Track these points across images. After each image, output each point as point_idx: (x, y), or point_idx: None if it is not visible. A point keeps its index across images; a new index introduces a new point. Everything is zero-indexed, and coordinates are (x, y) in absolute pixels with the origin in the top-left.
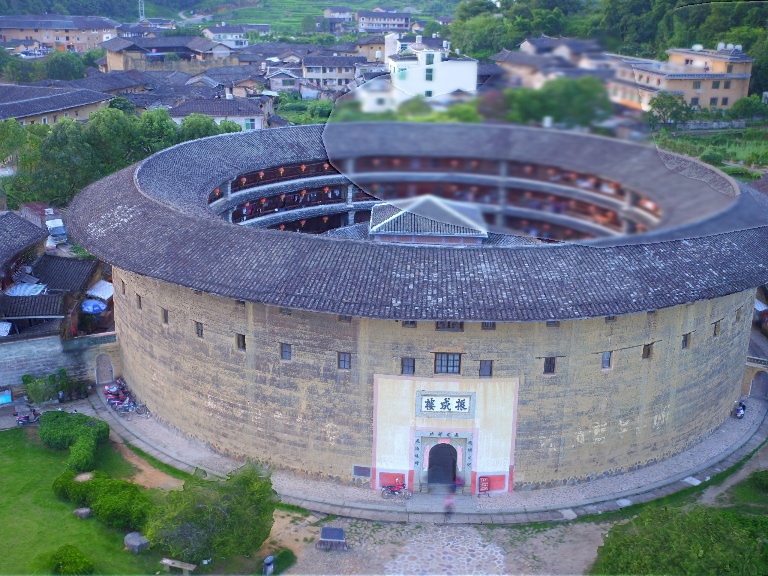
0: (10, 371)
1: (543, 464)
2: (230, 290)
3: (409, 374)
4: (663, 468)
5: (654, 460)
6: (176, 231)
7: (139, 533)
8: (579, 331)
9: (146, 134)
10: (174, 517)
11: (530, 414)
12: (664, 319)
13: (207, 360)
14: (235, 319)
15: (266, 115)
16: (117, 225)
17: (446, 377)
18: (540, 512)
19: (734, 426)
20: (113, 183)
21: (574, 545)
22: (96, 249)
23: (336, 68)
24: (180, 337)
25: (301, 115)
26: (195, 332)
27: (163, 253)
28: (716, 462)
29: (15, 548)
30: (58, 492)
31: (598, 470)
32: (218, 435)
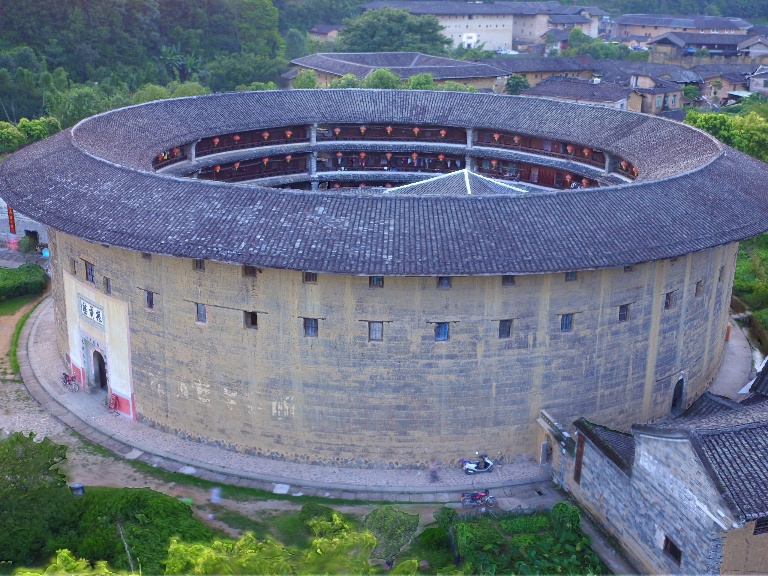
0: None
1: (156, 403)
2: None
3: None
4: (281, 466)
5: (282, 455)
6: None
7: None
8: (169, 271)
9: None
10: None
11: (140, 345)
12: (268, 288)
13: None
14: None
15: (656, 108)
16: None
17: (89, 285)
18: (120, 442)
19: (442, 475)
20: None
21: (84, 472)
22: None
23: None
24: None
25: (730, 116)
26: None
27: None
28: (339, 488)
29: None
30: None
31: (209, 435)
32: None
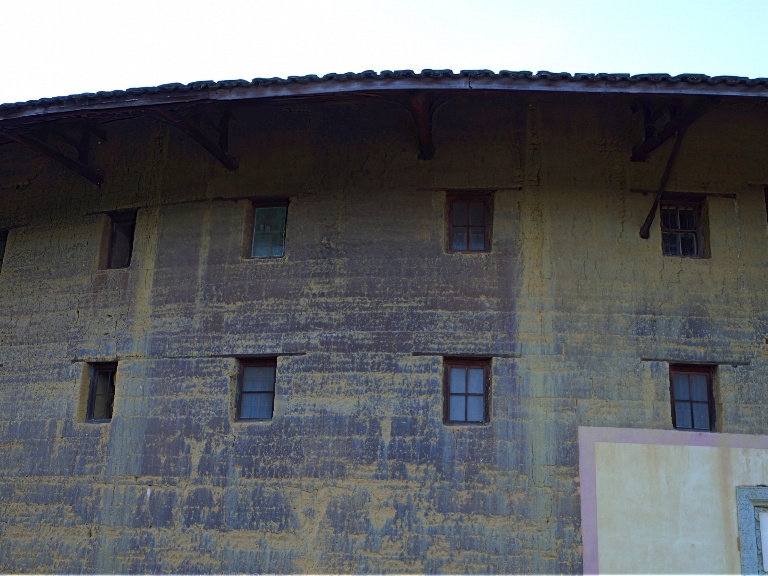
0: None
1: None
2: None
3: (696, 431)
4: None
5: None
6: None
7: None
8: None
9: None
10: None
11: None
12: None
13: None
14: (91, 314)
15: None
16: None
17: None
18: None
19: None
20: None
21: None
22: None
23: None
24: None
25: None
26: None
27: None
28: None
29: None
30: None
31: None
32: None
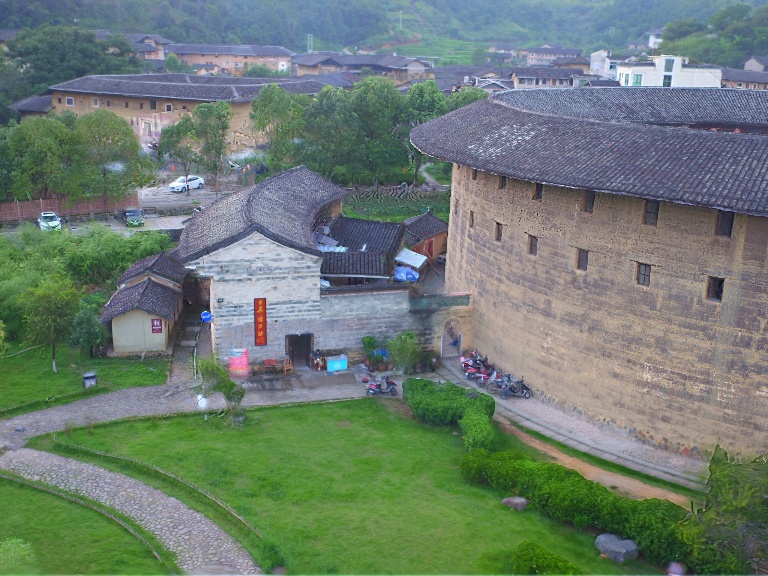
0: (348, 331)
1: None
2: (745, 203)
3: None
4: None
5: None
6: (617, 142)
7: (615, 536)
8: None
9: (415, 107)
10: (738, 508)
11: None
12: None
13: (651, 315)
14: (711, 256)
15: None
16: (517, 143)
17: None
18: None
19: None
20: (466, 114)
21: None
22: (500, 167)
23: (550, 80)
24: (606, 285)
25: None
26: (634, 277)
27: (612, 165)
28: None
29: (444, 542)
30: (472, 474)
31: None
32: (653, 419)
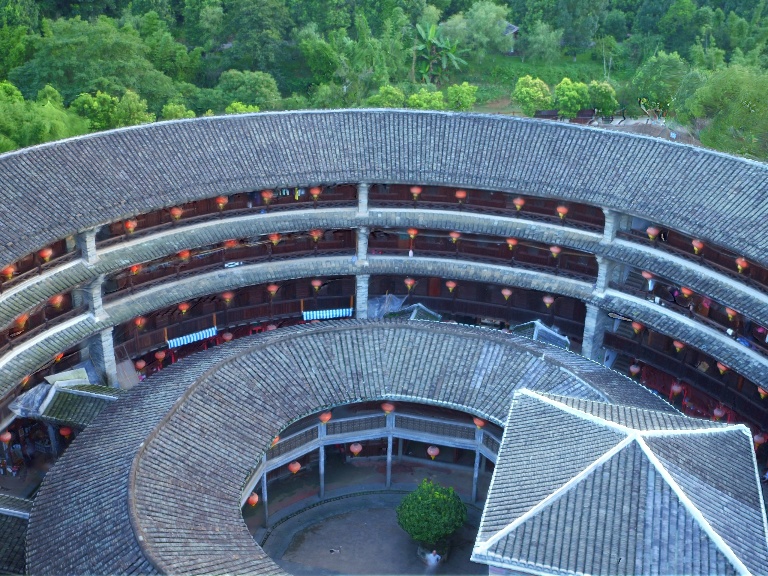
0: None
1: None
2: None
3: None
4: None
5: None
6: None
7: None
8: None
9: None
10: None
11: None
12: None
13: None
14: None
15: None
16: None
17: None
18: None
19: None
20: None
21: None
22: None
23: None
24: None
25: None
26: None
27: None
28: None
29: None
30: None
31: None
32: None
